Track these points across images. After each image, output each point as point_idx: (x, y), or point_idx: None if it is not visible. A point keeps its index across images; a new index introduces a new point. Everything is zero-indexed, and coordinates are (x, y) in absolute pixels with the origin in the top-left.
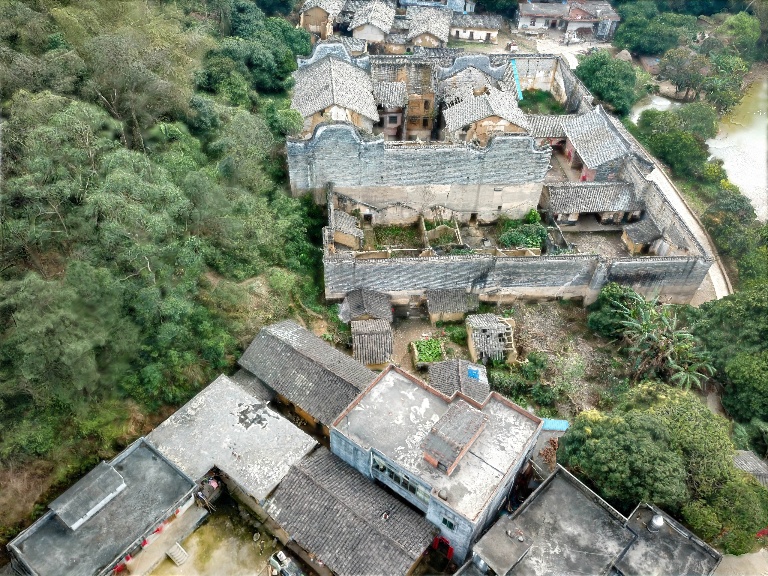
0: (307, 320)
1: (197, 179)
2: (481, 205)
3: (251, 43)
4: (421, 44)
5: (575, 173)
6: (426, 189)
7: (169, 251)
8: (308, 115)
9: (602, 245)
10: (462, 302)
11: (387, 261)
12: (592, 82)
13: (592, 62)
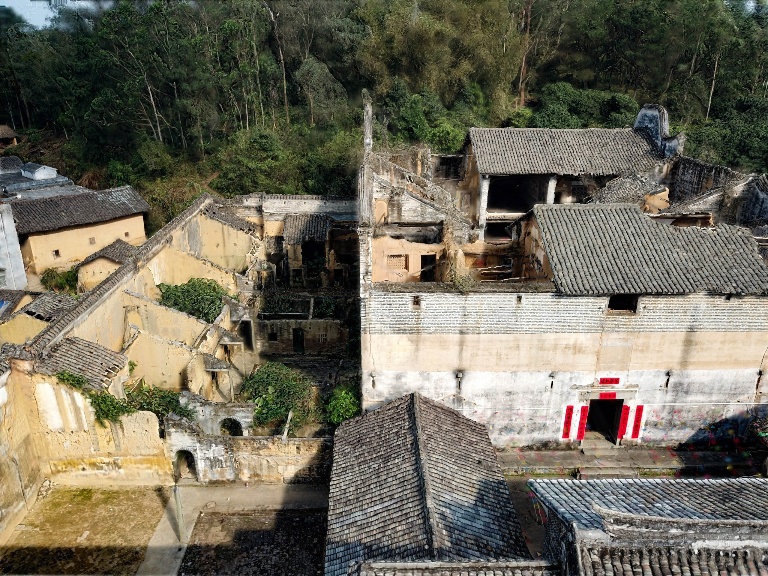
0: None
1: None
2: None
3: None
4: None
5: None
6: None
7: None
8: None
9: None
10: None
11: None
12: None
13: None
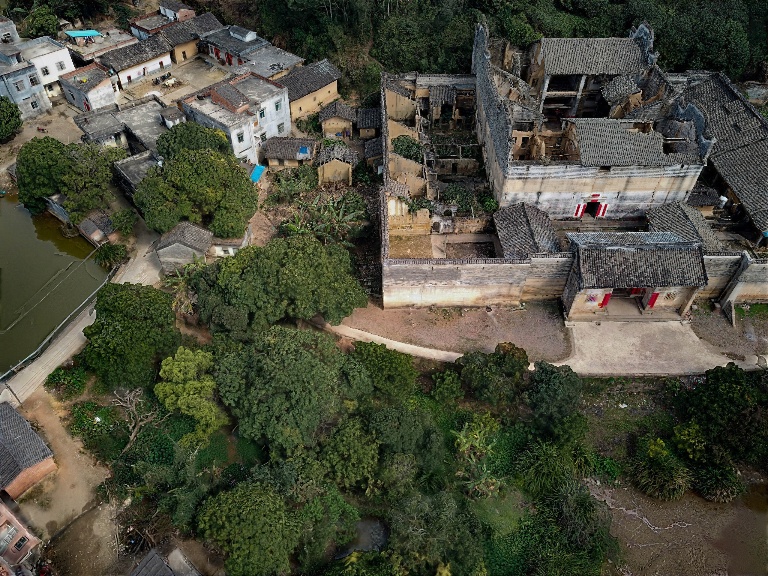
0: (360, 97)
1: None
2: None
3: None
4: None
5: None
6: None
7: None
8: None
9: None
10: (373, 154)
11: None
12: None
13: None
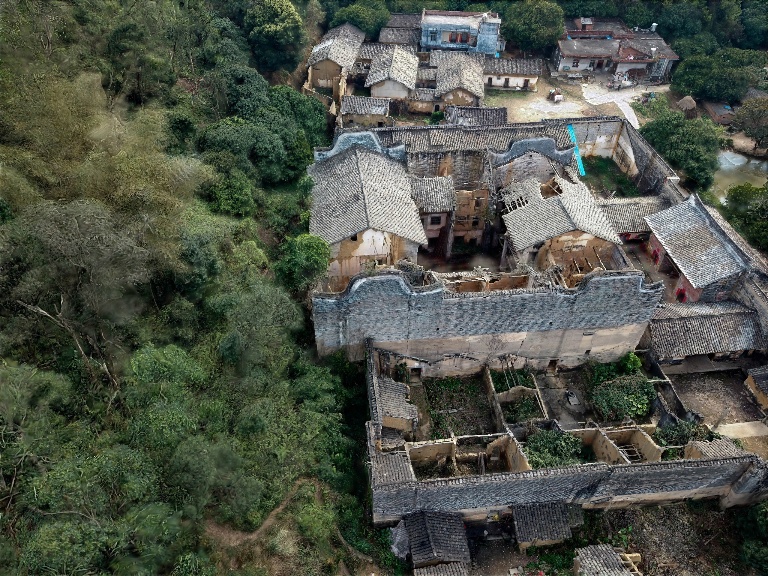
0: (351, 567)
1: (190, 459)
2: (564, 350)
3: (254, 128)
4: (452, 100)
5: (664, 279)
6: (494, 338)
7: (150, 557)
8: (334, 241)
9: (721, 395)
10: (562, 522)
11: (462, 483)
12: (665, 148)
13: (664, 124)
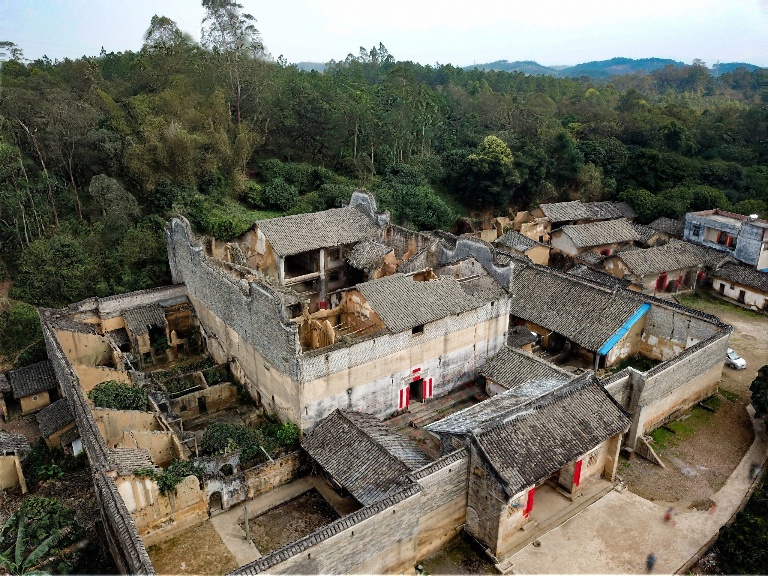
0: (9, 357)
1: None
2: None
3: (350, 190)
4: (613, 270)
5: None
6: (226, 329)
7: None
8: None
9: None
10: (56, 426)
11: None
12: None
13: None
